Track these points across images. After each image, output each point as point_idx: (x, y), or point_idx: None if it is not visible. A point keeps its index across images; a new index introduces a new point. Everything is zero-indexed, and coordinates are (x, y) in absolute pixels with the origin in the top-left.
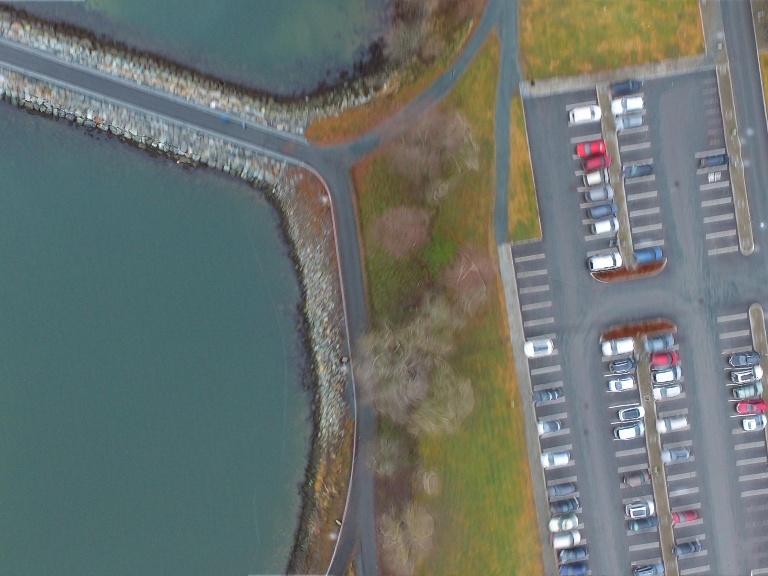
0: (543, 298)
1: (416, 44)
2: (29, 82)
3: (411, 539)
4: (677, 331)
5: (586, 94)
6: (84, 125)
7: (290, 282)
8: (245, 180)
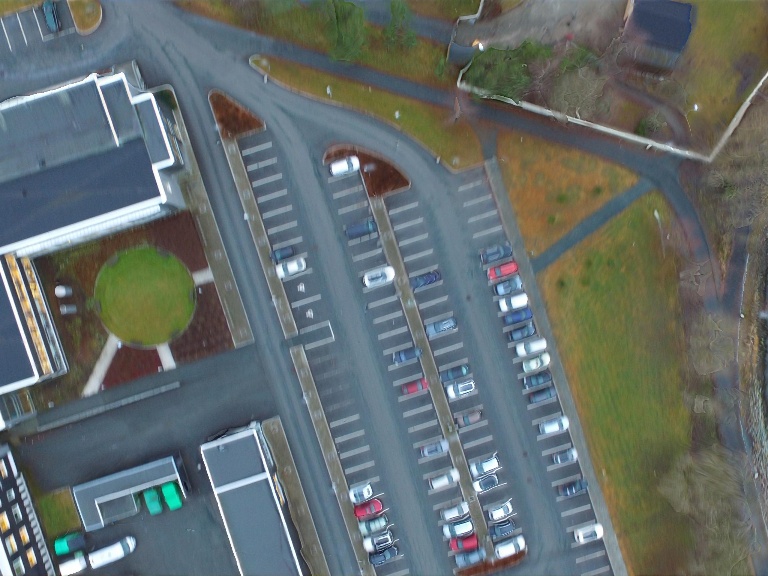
0: None
1: None
2: None
3: (707, 341)
4: (453, 570)
5: None
6: None
7: None
8: None
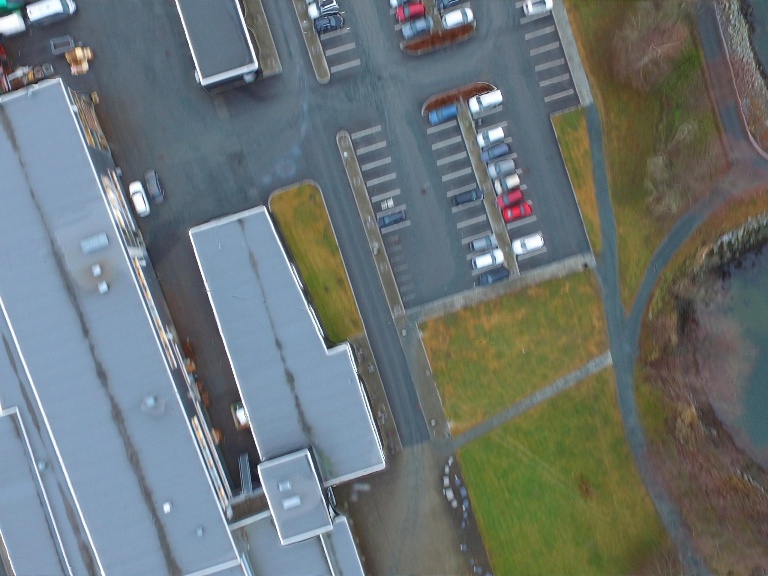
0: (540, 57)
1: (680, 301)
2: None
3: None
4: (400, 44)
5: (529, 265)
6: None
7: (763, 54)
8: None
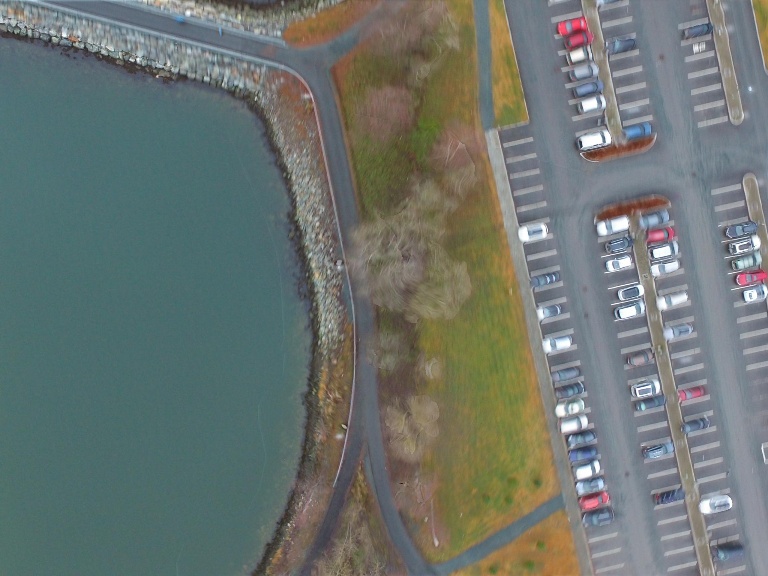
0: (534, 182)
1: None
2: (1, 3)
3: (417, 429)
4: (671, 206)
5: None
6: (60, 45)
7: (279, 191)
8: (226, 90)
